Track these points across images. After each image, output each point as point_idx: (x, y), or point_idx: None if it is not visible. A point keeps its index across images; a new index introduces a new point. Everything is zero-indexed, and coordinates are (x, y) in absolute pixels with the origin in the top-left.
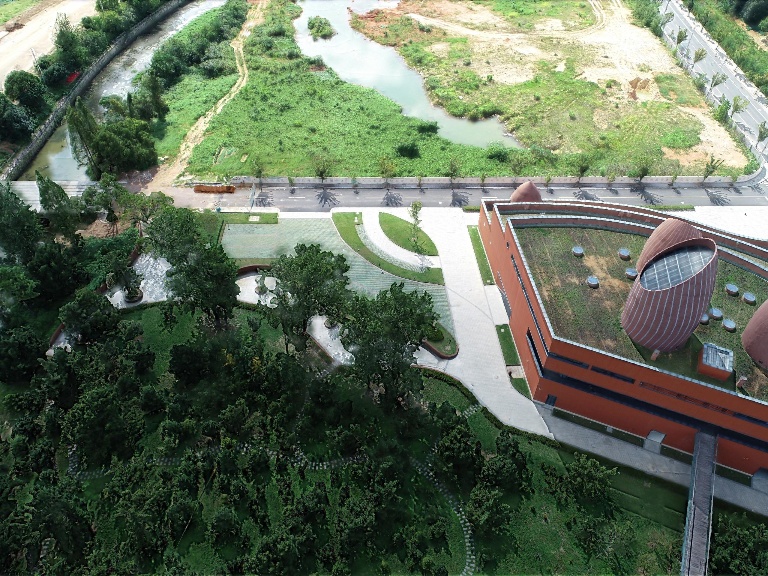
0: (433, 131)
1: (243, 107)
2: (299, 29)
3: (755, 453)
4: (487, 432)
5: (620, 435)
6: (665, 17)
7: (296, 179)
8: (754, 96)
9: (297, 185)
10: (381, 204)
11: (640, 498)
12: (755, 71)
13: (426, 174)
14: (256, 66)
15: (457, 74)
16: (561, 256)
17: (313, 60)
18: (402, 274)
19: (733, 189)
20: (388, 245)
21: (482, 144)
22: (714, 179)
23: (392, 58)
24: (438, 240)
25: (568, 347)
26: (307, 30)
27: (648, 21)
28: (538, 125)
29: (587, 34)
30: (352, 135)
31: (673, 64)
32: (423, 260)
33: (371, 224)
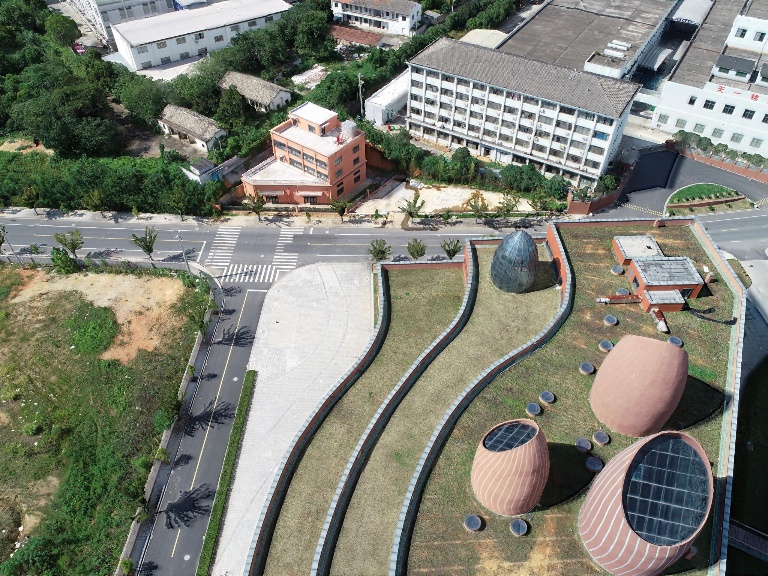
0: None
1: None
2: None
3: None
4: None
5: None
6: None
7: None
8: (41, 218)
9: None
10: None
11: None
12: None
13: None
14: None
15: None
16: None
17: None
18: None
19: (224, 315)
20: None
21: None
22: None
23: None
24: None
25: None
26: None
27: None
28: None
29: None
30: None
31: None
32: None
33: None
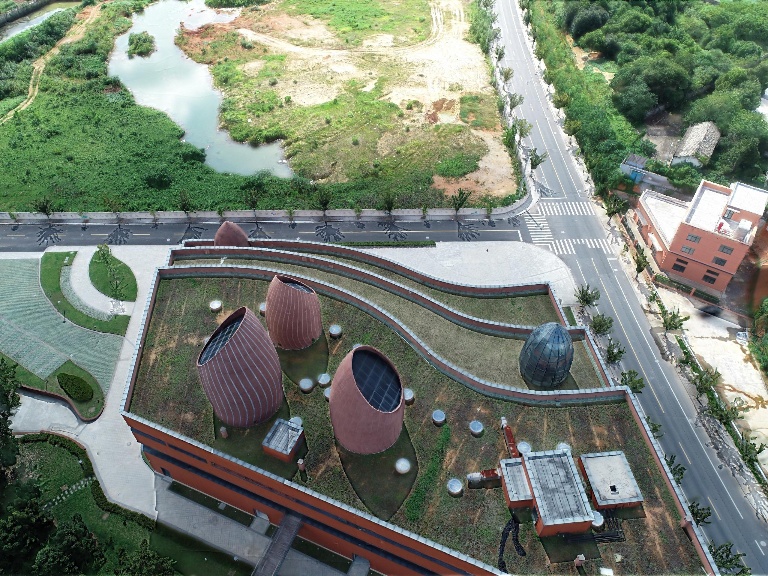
0: (198, 159)
1: (8, 133)
2: (120, 46)
3: (338, 539)
4: (83, 511)
5: (230, 512)
6: (492, 33)
7: (21, 214)
8: (556, 118)
9: (23, 221)
10: (104, 242)
11: None
12: (564, 91)
13: (166, 207)
14: (45, 87)
15: (255, 95)
16: (196, 311)
17: (110, 80)
18: (84, 323)
19: (488, 222)
20: (86, 289)
21: (250, 172)
22: (469, 211)
23: (201, 77)
24: (144, 283)
25: (137, 423)
26: (126, 47)
27: (479, 37)
28: (316, 151)
29: (413, 50)
30: (109, 164)
31: (487, 83)
32: (116, 306)
33: (80, 265)
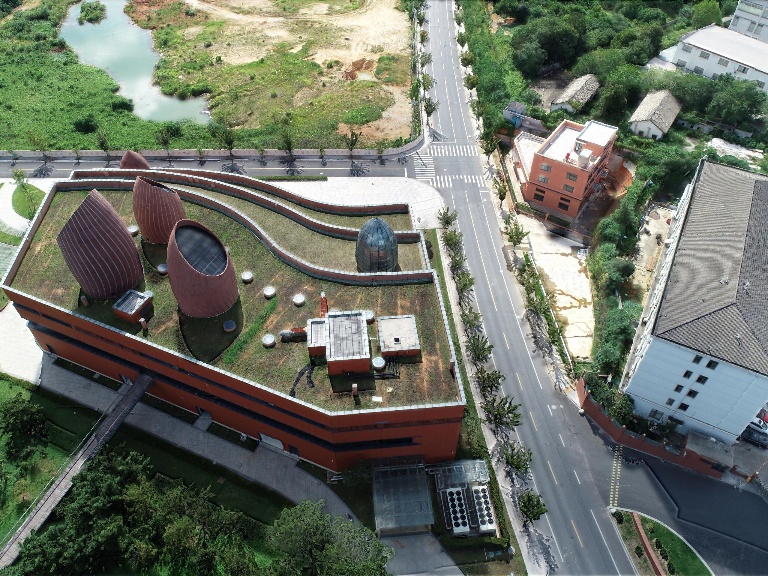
0: (125, 108)
1: None
2: (73, 13)
3: (181, 392)
4: None
5: (103, 380)
6: (417, 1)
7: None
8: (463, 75)
9: None
10: (29, 175)
11: (76, 434)
12: None
13: (90, 148)
14: None
15: (189, 55)
16: None
17: (57, 42)
18: (1, 238)
19: (379, 161)
20: (7, 212)
21: (174, 121)
22: (363, 152)
23: (143, 41)
24: None
25: (14, 295)
26: (78, 14)
27: None
28: (236, 103)
29: (345, 18)
30: (44, 112)
31: (407, 46)
32: None
33: (5, 193)
